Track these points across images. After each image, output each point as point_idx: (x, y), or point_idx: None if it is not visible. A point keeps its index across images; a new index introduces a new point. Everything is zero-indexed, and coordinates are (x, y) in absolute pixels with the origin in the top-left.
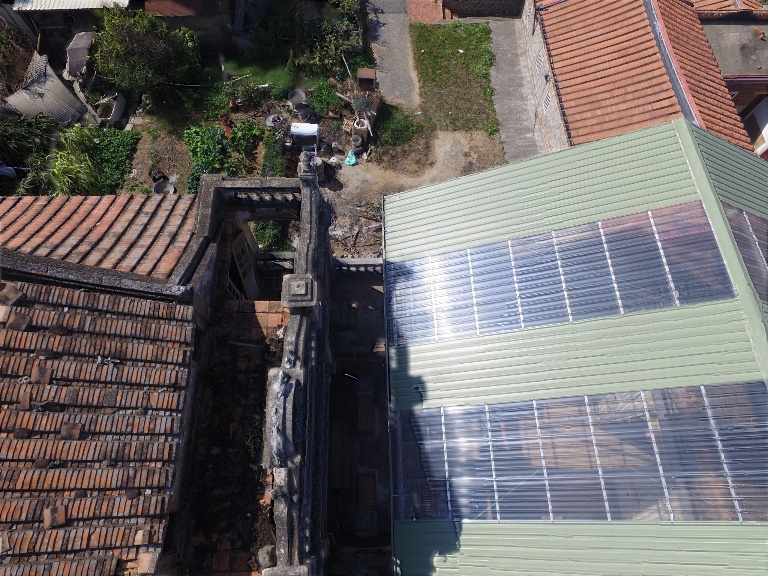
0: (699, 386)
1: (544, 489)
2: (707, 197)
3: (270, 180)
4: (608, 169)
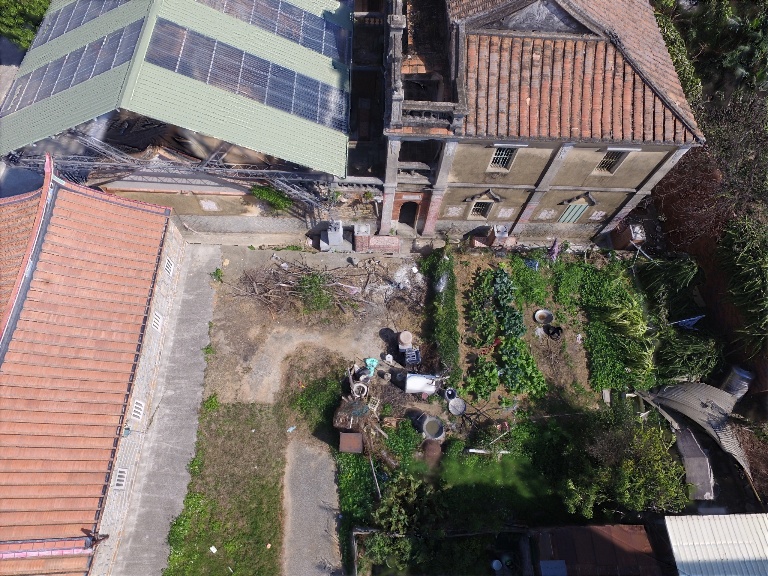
0: (197, 2)
1: (281, 8)
2: (141, 57)
3: (423, 105)
4: (186, 107)
